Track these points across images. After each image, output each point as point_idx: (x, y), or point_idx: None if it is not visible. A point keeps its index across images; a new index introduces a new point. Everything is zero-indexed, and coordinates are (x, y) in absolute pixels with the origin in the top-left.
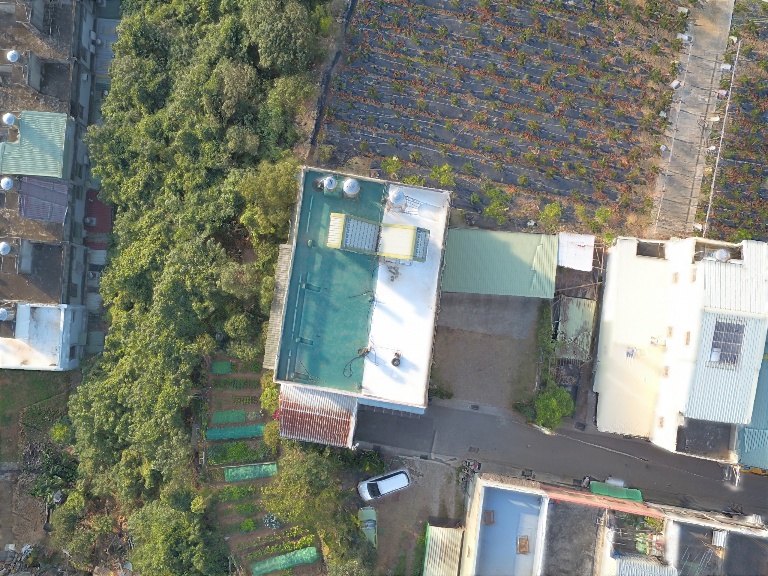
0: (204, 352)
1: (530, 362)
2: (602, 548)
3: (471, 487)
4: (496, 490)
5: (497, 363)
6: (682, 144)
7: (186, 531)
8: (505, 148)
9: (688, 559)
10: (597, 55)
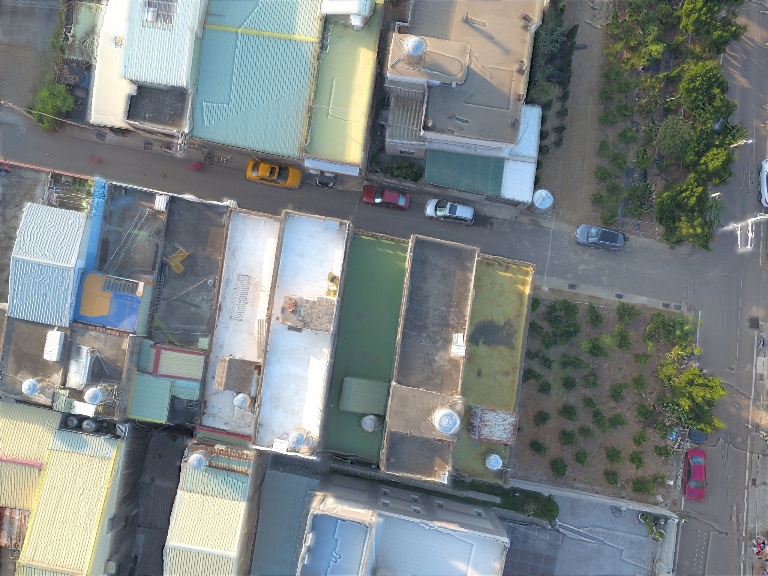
0: None
1: None
2: None
3: None
4: None
5: (21, 74)
6: None
7: None
8: None
9: None
10: None
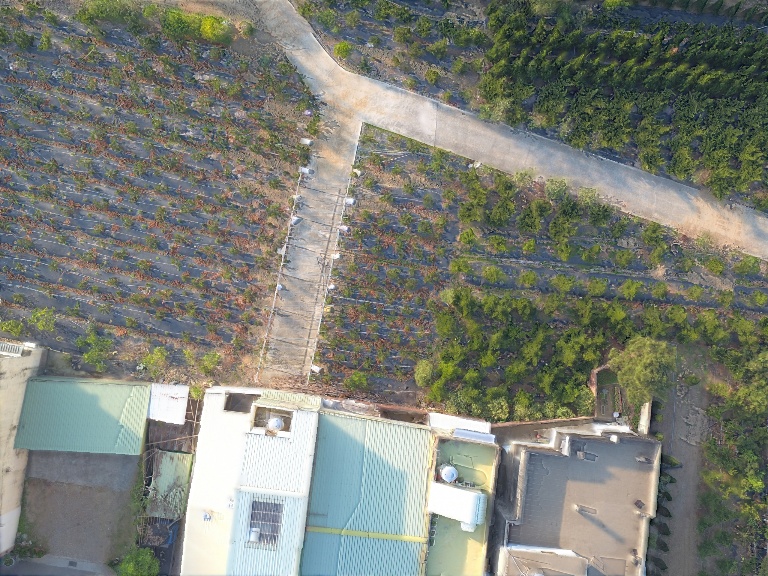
0: None
1: (131, 515)
2: None
3: None
4: None
5: (97, 517)
6: (300, 283)
7: None
8: (114, 288)
9: None
10: (214, 189)
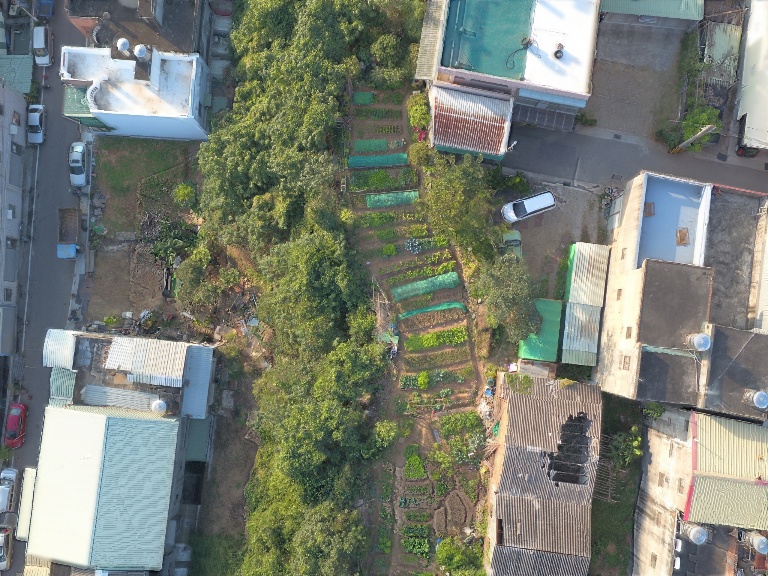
0: (352, 71)
1: (673, 93)
2: (765, 235)
3: (621, 199)
4: (656, 183)
5: (640, 93)
6: None
7: (331, 249)
8: None
9: None
10: None
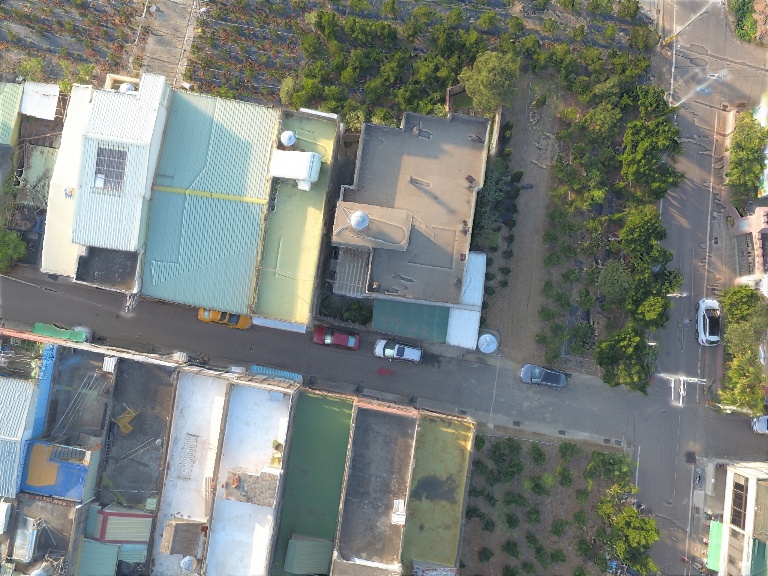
0: None
1: None
2: None
3: None
4: None
5: None
6: (174, 5)
7: None
8: None
9: (87, 387)
10: None
